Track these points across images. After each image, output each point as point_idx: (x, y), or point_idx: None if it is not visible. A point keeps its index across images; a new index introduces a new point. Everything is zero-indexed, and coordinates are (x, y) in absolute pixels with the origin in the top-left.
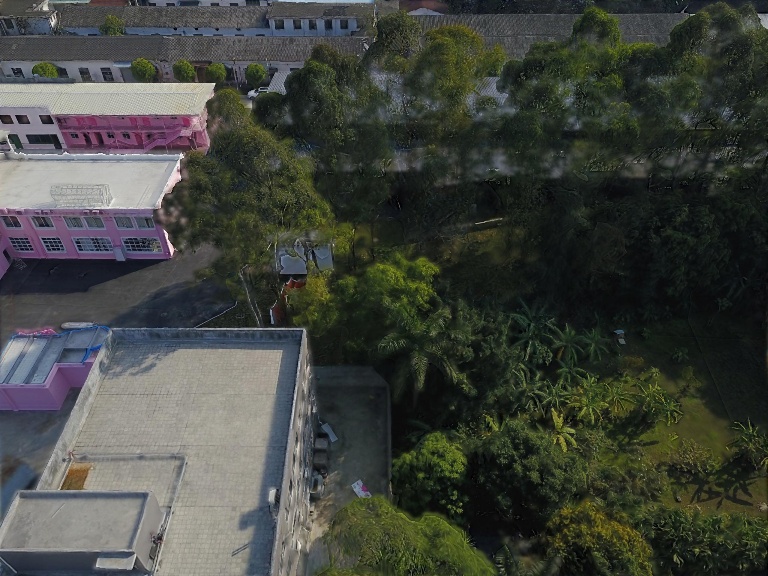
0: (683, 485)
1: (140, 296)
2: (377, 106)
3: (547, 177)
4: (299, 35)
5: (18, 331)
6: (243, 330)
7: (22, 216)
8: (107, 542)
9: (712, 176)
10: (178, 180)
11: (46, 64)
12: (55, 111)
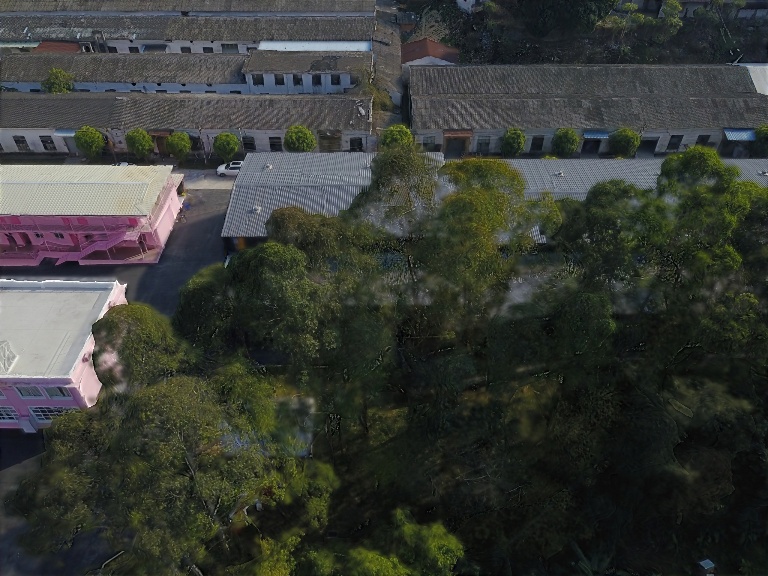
0: None
1: None
2: (370, 284)
3: (618, 376)
4: (282, 91)
5: None
6: None
7: None
8: None
9: None
10: None
11: None
12: None
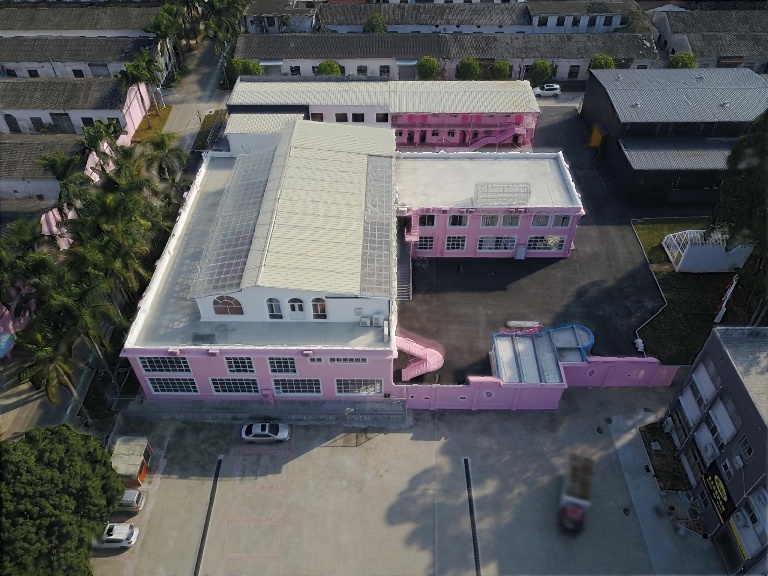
0: None
1: (563, 295)
2: None
3: None
4: (559, 32)
5: (466, 330)
6: None
7: (444, 215)
8: None
9: None
10: (571, 178)
11: (332, 62)
12: (393, 109)
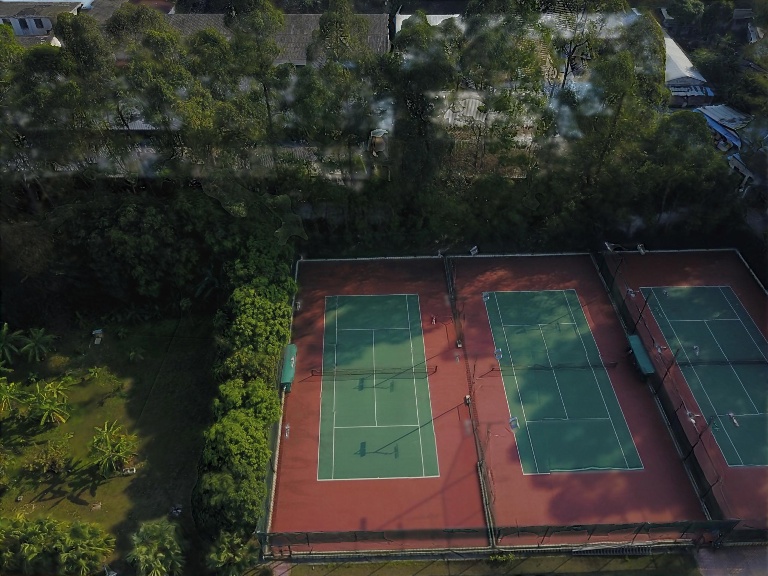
0: (36, 484)
1: None
2: None
3: None
4: None
5: None
6: None
7: None
8: None
9: (126, 176)
10: None
11: None
12: None
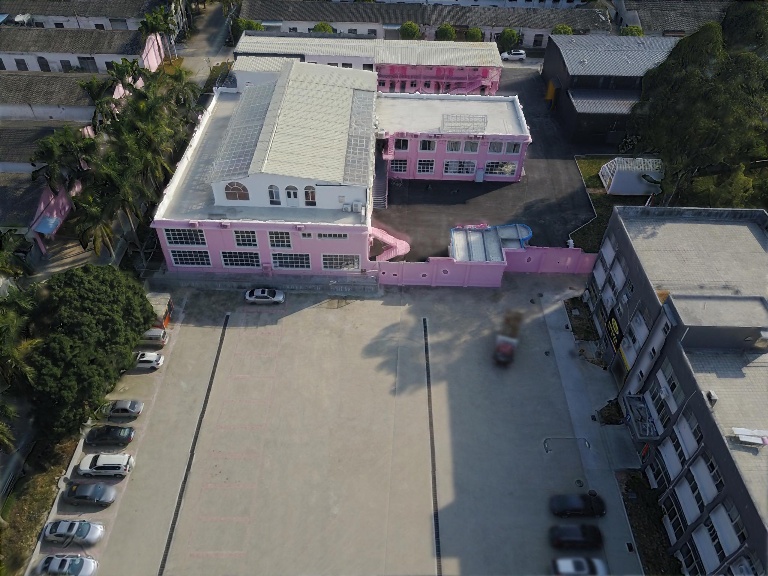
0: None
1: (513, 208)
2: None
3: None
4: None
5: (430, 231)
6: (717, 210)
7: (415, 139)
8: (758, 323)
9: None
10: None
11: (326, 24)
12: (377, 61)
